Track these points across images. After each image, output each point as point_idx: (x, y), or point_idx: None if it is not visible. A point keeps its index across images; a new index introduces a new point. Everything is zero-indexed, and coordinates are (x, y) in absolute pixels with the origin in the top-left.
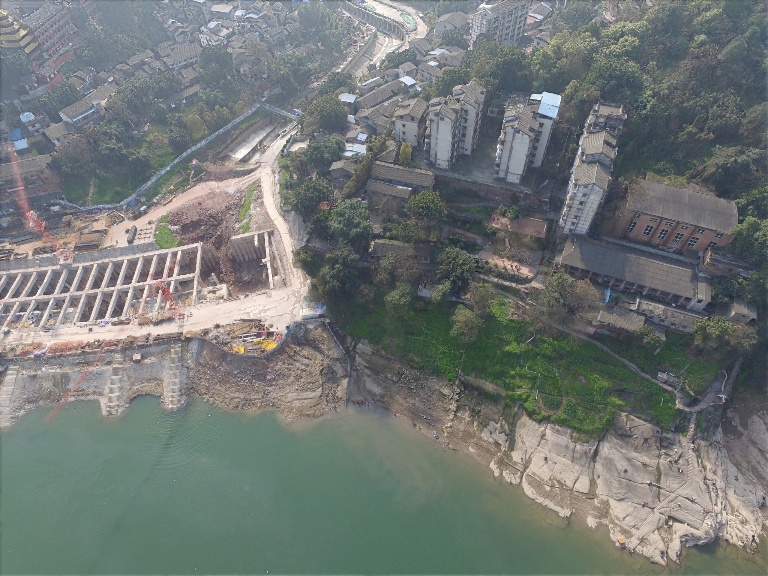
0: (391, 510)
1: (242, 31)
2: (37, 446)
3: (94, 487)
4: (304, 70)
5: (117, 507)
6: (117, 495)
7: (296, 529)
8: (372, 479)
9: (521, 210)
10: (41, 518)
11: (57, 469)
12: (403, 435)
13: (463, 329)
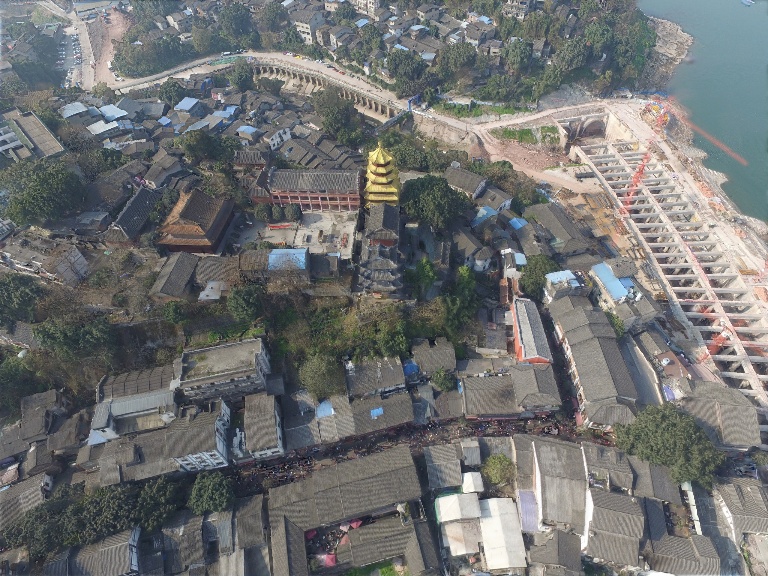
0: (713, 86)
1: (260, 119)
2: (766, 204)
3: None
4: (339, 97)
5: None
6: (767, 164)
7: None
8: (701, 91)
9: (566, 2)
10: None
11: None
12: (674, 83)
13: (641, 31)
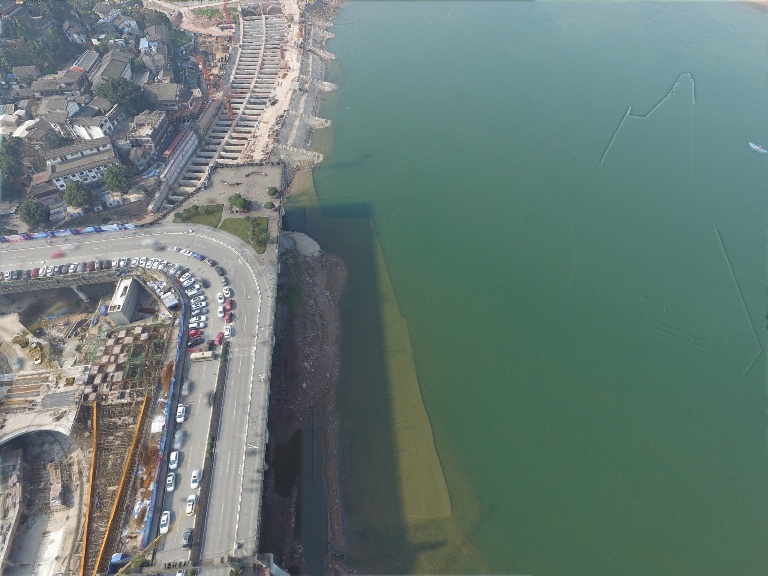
0: None
1: None
2: None
3: (364, 35)
4: None
5: (372, 28)
6: None
7: (381, 2)
8: None
9: None
10: (375, 41)
11: (357, 39)
12: None
13: None
